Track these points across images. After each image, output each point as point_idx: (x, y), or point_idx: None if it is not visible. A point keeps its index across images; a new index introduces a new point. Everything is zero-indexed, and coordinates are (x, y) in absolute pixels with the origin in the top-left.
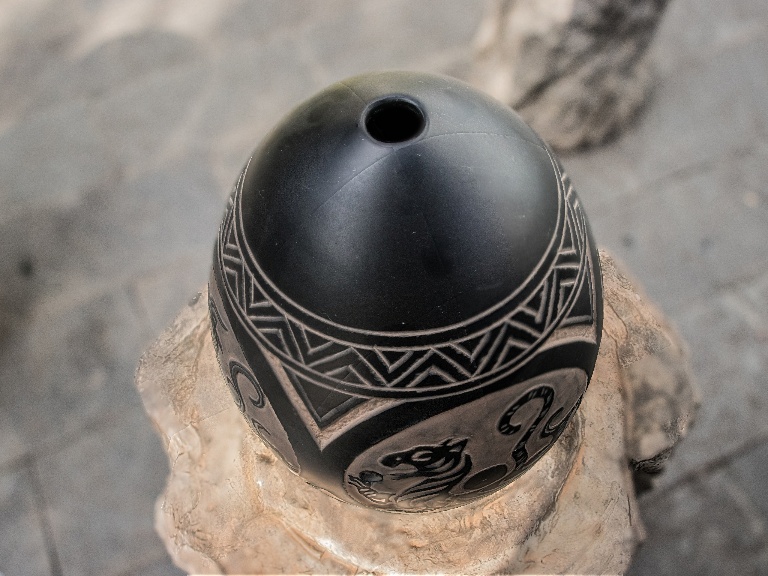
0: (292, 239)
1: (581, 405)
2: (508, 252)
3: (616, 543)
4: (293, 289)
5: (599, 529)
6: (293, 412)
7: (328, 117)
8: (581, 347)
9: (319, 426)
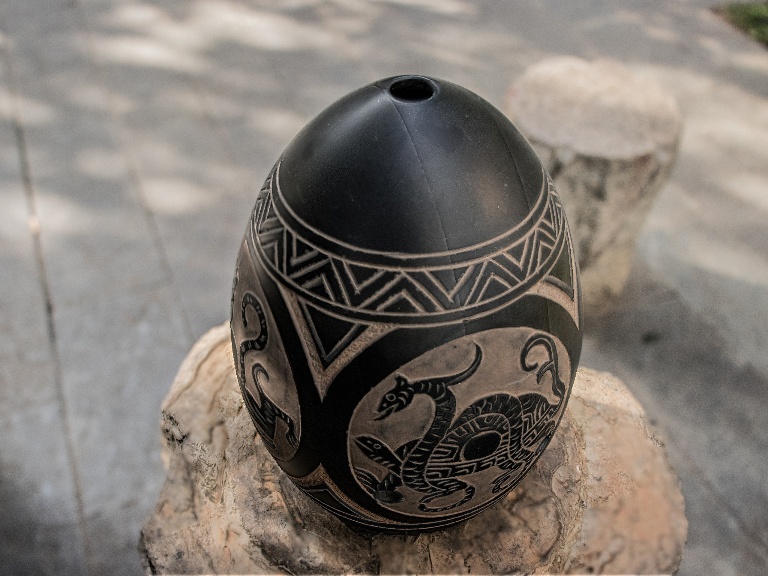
0: None
1: None
2: (323, 195)
3: None
4: None
5: None
6: None
7: None
8: (301, 355)
9: None
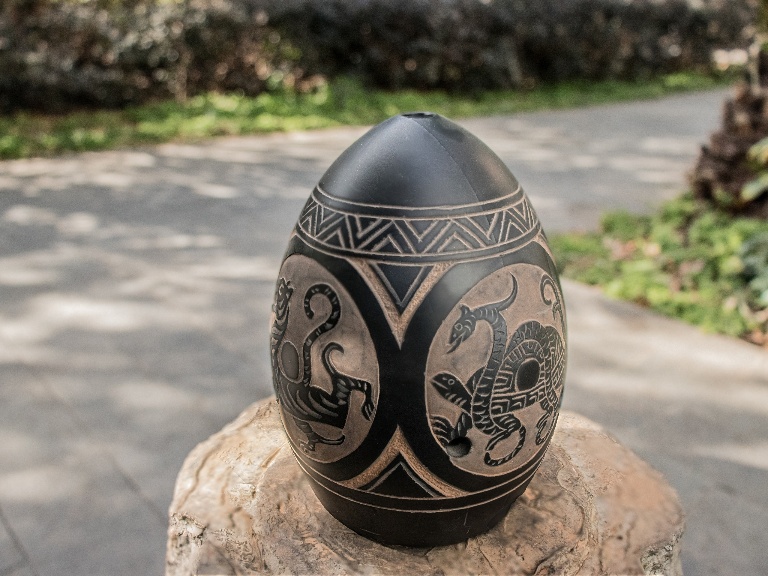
0: None
1: None
2: (377, 181)
3: None
4: None
5: None
6: None
7: None
8: (378, 311)
9: None
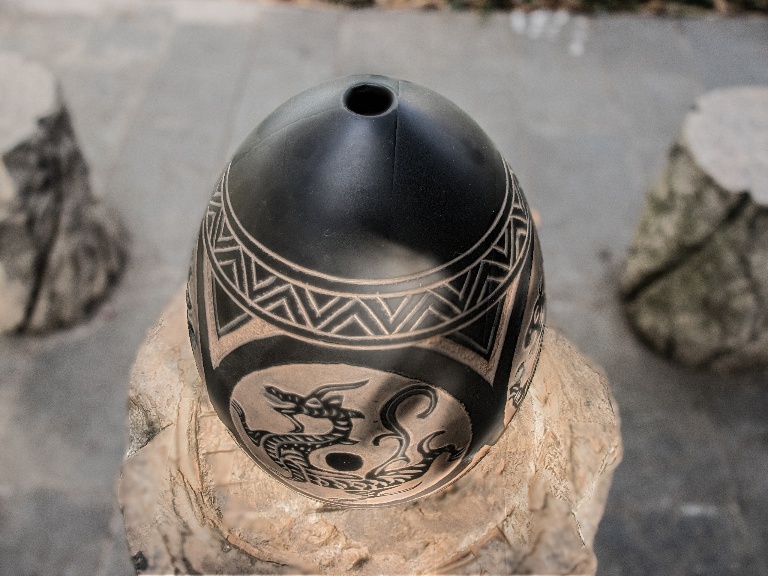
0: (393, 228)
1: None
2: (480, 129)
3: (555, 342)
4: (422, 261)
5: (542, 346)
6: (466, 371)
7: (322, 139)
8: None
9: (487, 359)
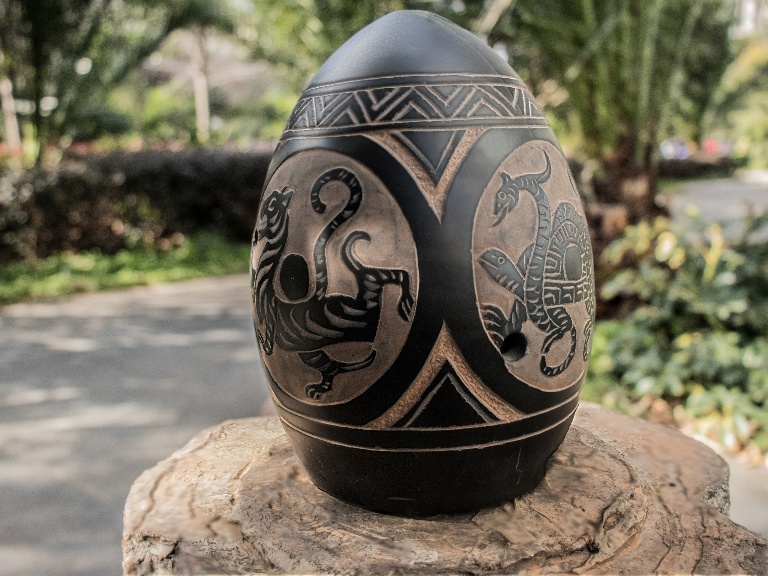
0: None
1: (534, 575)
2: (385, 55)
3: None
4: None
5: None
6: None
7: None
8: (408, 183)
9: None
